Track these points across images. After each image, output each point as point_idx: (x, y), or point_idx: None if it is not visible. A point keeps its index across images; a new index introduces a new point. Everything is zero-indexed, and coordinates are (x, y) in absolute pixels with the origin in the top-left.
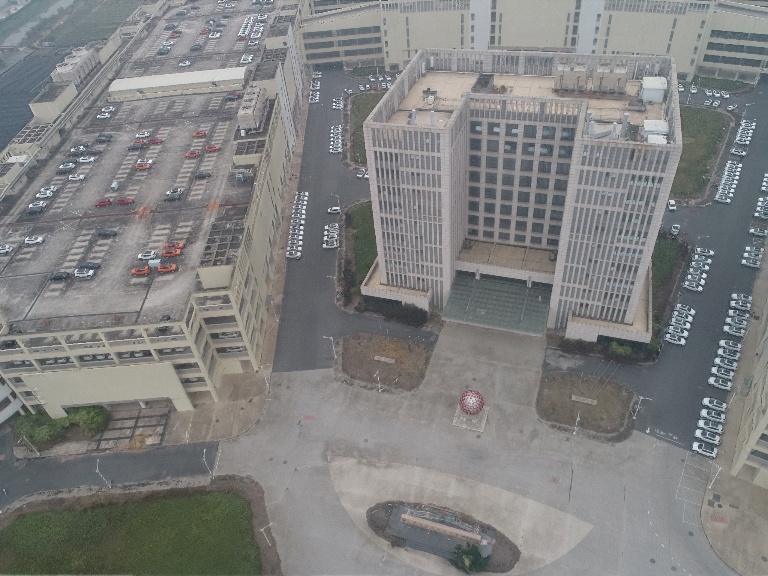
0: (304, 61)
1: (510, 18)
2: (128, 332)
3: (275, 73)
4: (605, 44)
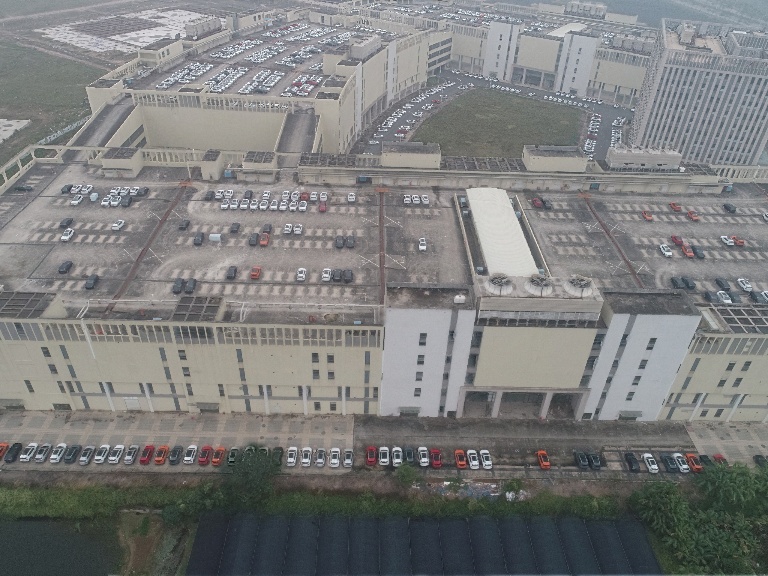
0: None
1: None
2: None
3: (554, 150)
4: None
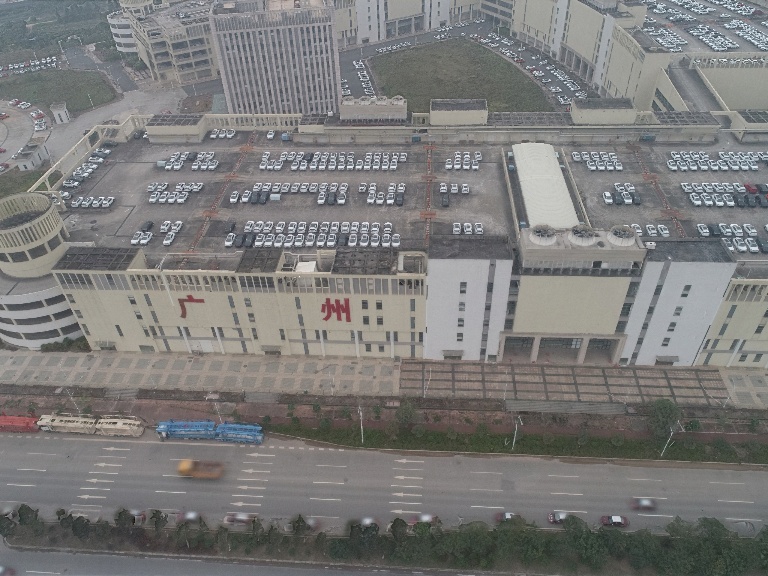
0: (480, 8)
1: (575, 21)
2: (151, 32)
3: None
4: (607, 70)
